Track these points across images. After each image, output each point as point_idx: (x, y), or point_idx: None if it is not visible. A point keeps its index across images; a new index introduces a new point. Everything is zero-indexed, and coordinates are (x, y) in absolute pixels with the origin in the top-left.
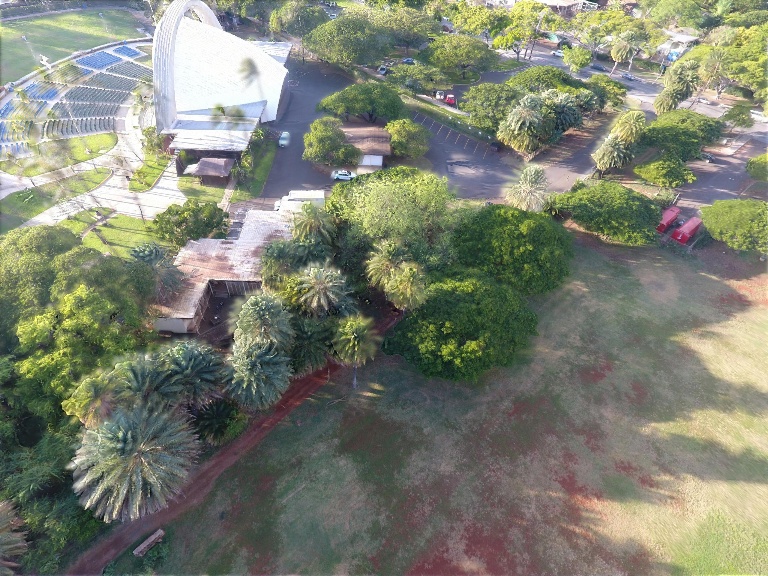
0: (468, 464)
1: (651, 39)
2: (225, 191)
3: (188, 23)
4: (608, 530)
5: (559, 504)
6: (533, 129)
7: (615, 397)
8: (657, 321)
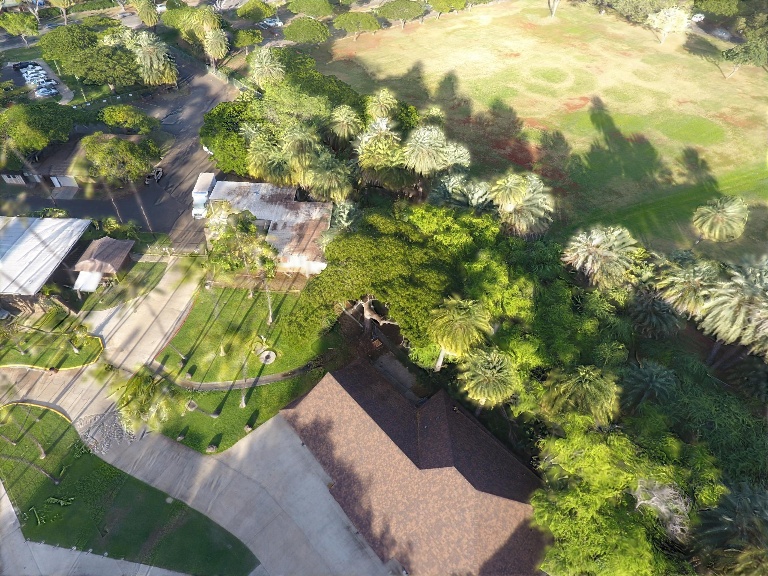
0: (462, 145)
1: None
2: (143, 261)
3: None
4: (483, 117)
5: (475, 125)
6: (172, 56)
7: (415, 103)
8: (364, 82)
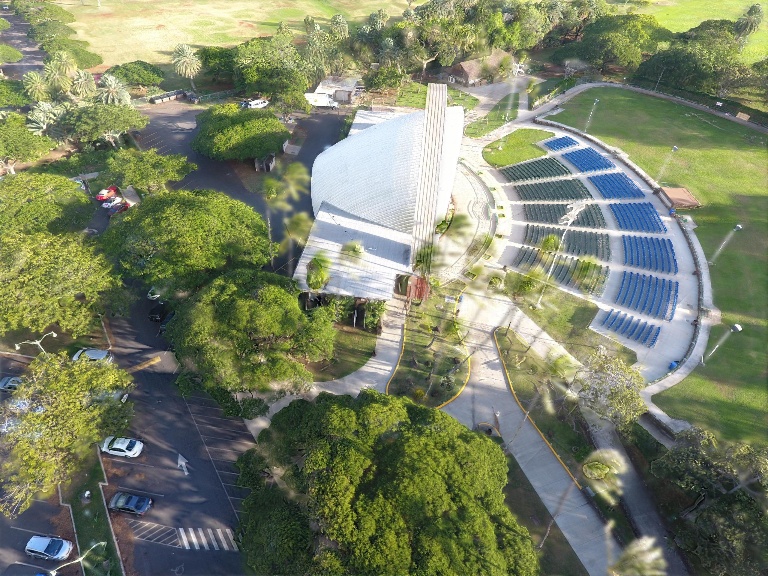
0: None
1: None
2: None
3: None
4: None
5: None
6: None
7: None
8: None
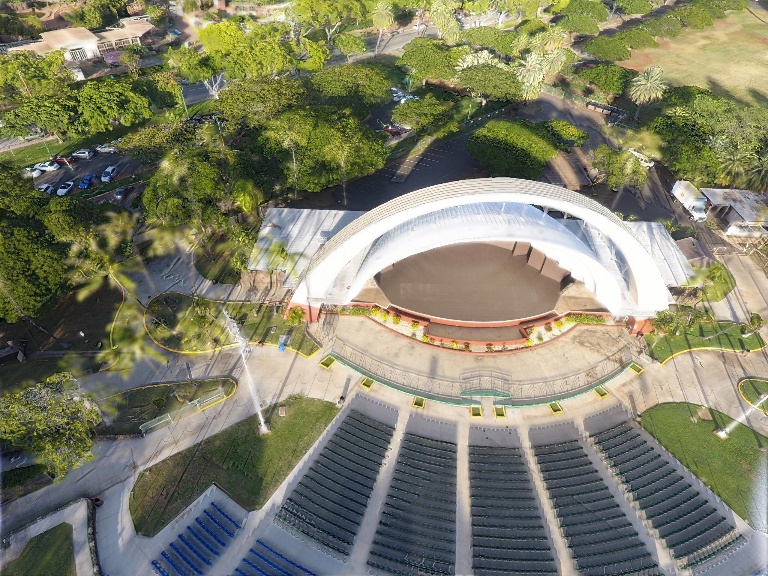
0: None
1: (352, 6)
2: None
3: (498, 214)
4: None
5: None
6: (543, 74)
7: None
8: None
